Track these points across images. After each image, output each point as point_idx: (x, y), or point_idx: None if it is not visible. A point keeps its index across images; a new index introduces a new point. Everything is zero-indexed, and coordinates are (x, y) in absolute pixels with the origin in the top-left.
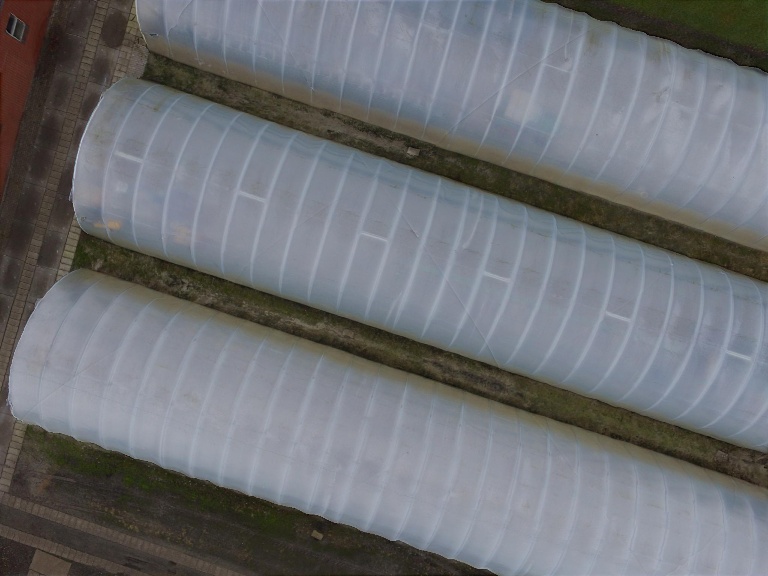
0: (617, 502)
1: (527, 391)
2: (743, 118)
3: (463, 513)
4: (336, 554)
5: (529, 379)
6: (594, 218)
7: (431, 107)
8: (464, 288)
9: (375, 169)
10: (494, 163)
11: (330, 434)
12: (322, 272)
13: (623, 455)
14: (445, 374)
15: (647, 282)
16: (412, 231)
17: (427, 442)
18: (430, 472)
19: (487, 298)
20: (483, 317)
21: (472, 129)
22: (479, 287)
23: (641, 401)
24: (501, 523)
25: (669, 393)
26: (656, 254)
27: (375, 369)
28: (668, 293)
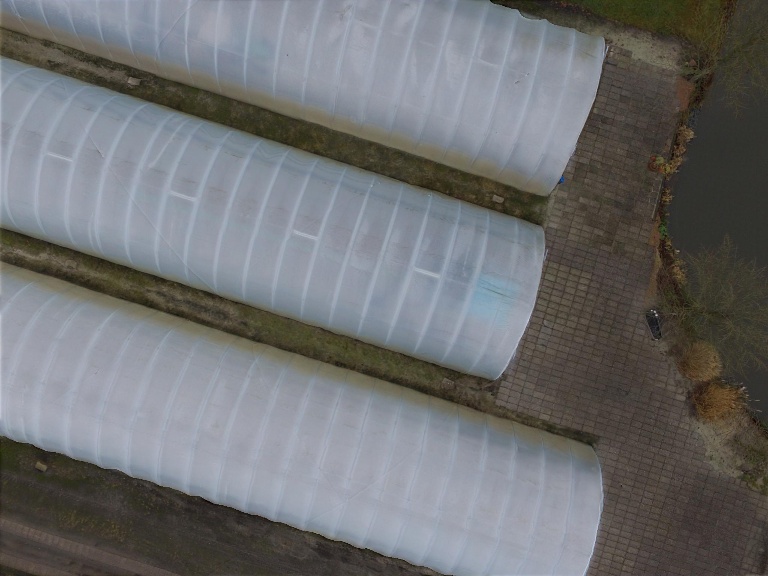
0: (311, 422)
1: (251, 320)
2: (427, 36)
3: (151, 433)
4: (60, 486)
5: (252, 308)
6: (315, 146)
7: (128, 31)
8: (151, 208)
9: (72, 93)
10: (214, 92)
11: (17, 355)
12: (14, 194)
13: (335, 380)
14: (169, 304)
15: (338, 201)
16: (98, 151)
17: (118, 363)
18: (117, 392)
19: (175, 218)
20: (175, 238)
21: (175, 54)
22: (165, 206)
23: (350, 325)
24: (190, 443)
25: (366, 313)
26: (363, 178)
27: (91, 297)
28: (358, 212)
